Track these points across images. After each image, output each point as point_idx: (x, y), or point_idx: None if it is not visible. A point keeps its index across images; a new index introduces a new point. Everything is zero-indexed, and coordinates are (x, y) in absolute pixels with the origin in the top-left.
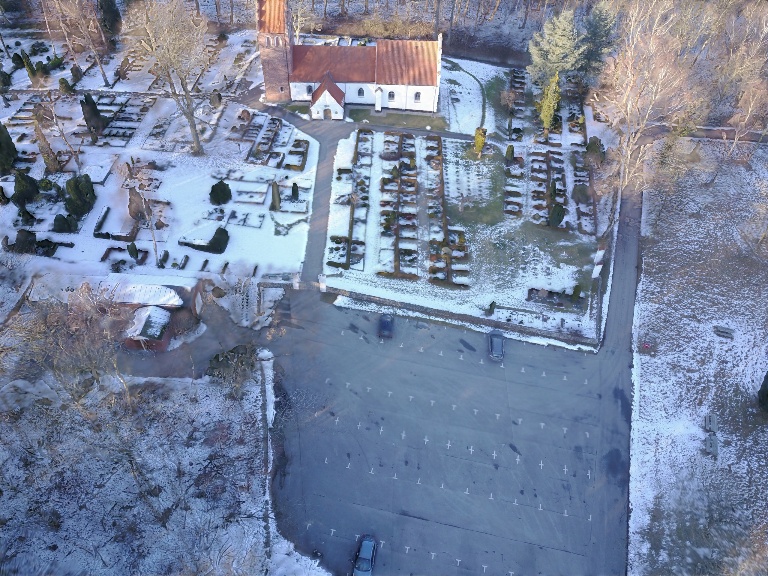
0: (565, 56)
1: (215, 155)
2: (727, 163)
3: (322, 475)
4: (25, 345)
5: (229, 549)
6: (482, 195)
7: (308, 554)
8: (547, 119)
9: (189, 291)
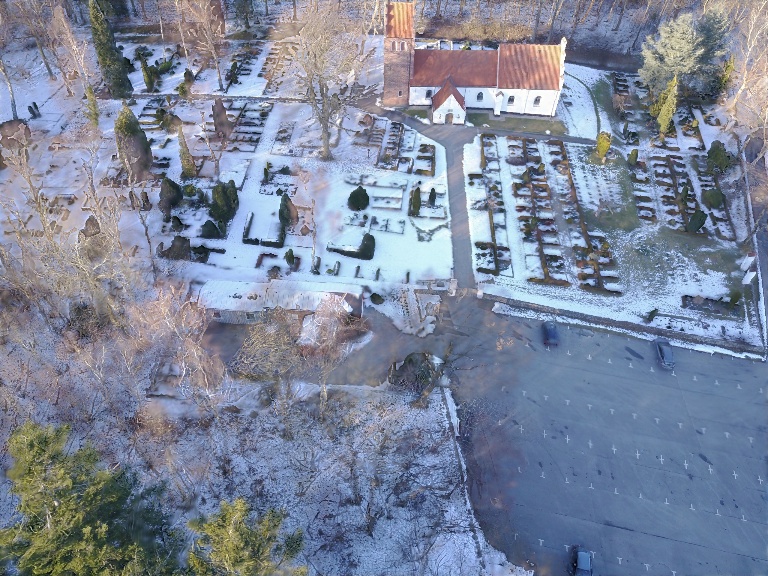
0: (681, 59)
1: (344, 160)
2: None
3: (518, 484)
4: (273, 356)
5: (444, 559)
6: (614, 200)
7: (521, 564)
8: (665, 123)
9: (357, 298)
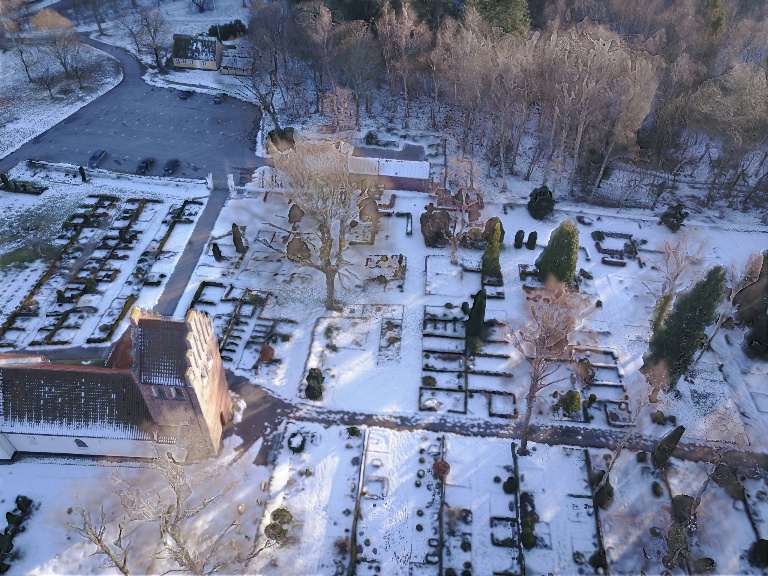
0: None
1: (310, 302)
2: None
3: None
4: None
5: None
6: (3, 276)
7: None
8: None
9: None
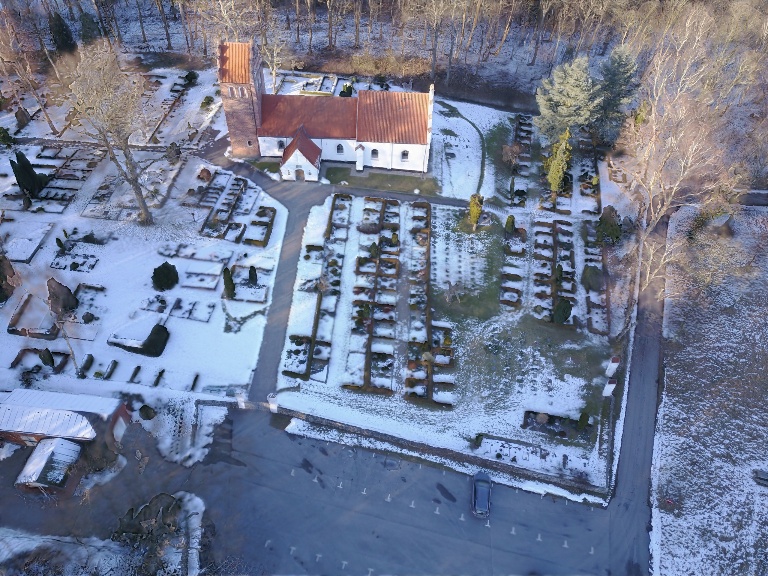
0: (578, 108)
1: (165, 225)
2: (765, 240)
3: None
4: None
5: None
6: (475, 280)
7: None
8: (555, 182)
9: (104, 420)
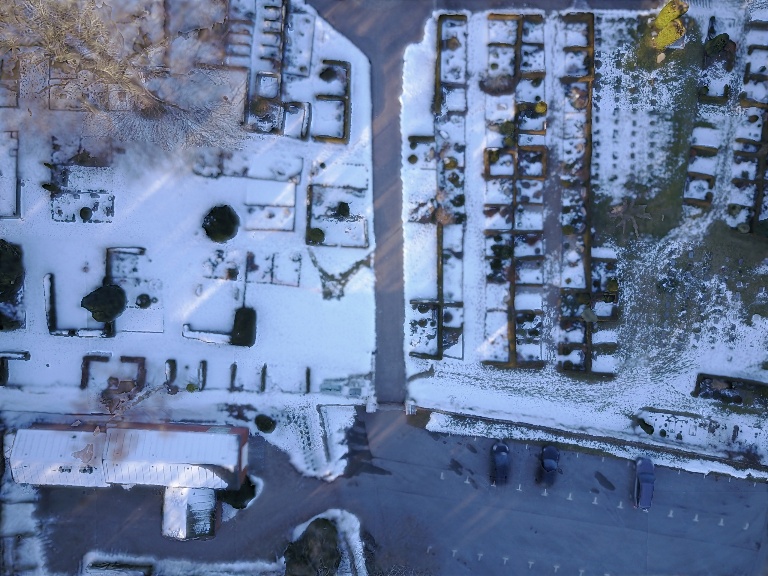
0: None
1: (186, 113)
2: None
3: None
4: None
5: None
6: (653, 168)
7: None
8: None
9: (232, 472)
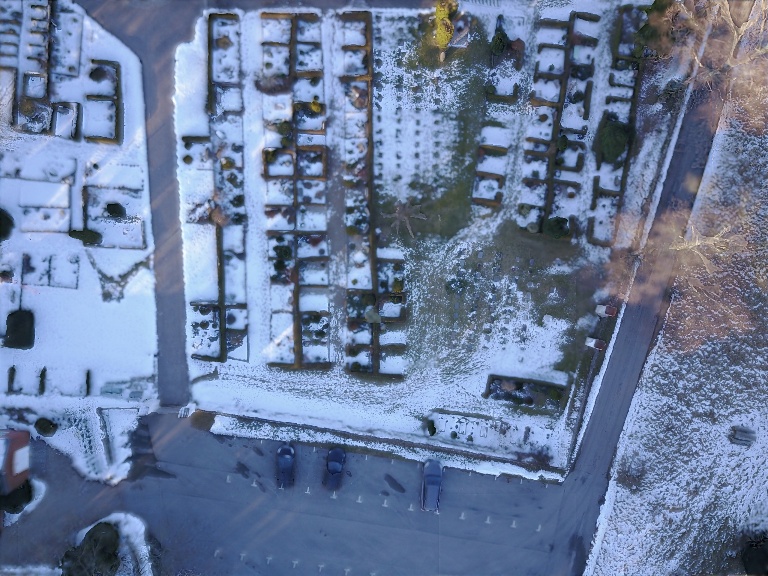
0: None
1: None
2: None
3: None
4: None
5: None
6: (438, 167)
7: None
8: None
9: None
